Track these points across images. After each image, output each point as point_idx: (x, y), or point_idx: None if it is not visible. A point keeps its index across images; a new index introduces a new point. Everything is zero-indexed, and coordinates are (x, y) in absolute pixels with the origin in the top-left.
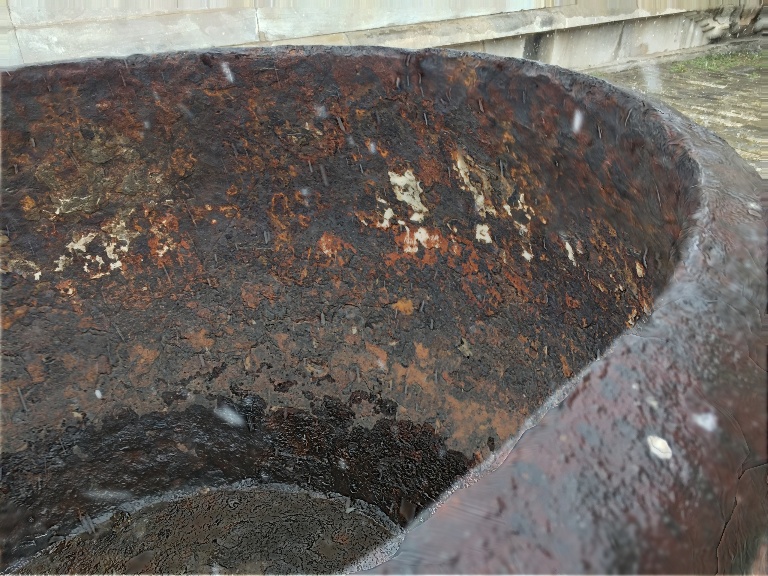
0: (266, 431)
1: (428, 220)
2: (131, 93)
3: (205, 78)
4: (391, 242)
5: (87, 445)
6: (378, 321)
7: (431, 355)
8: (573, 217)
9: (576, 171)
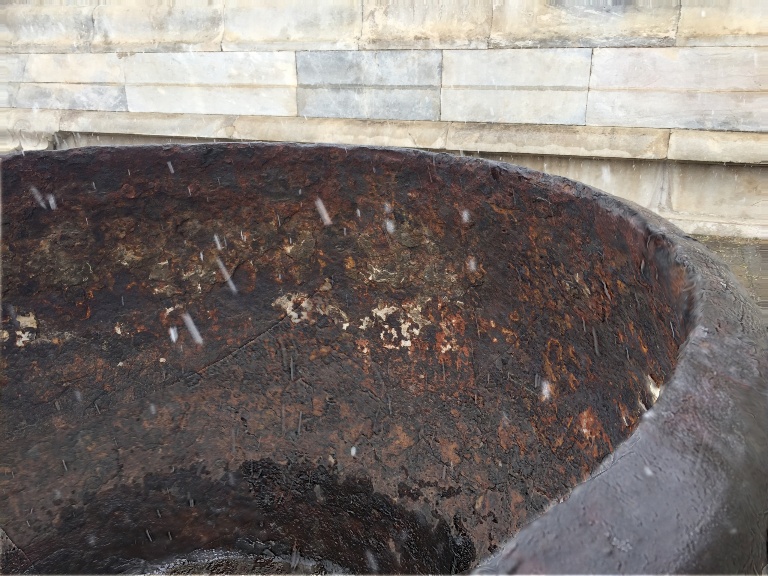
0: None
1: None
2: (436, 190)
3: (494, 192)
4: None
5: (326, 490)
6: None
7: None
8: None
9: None
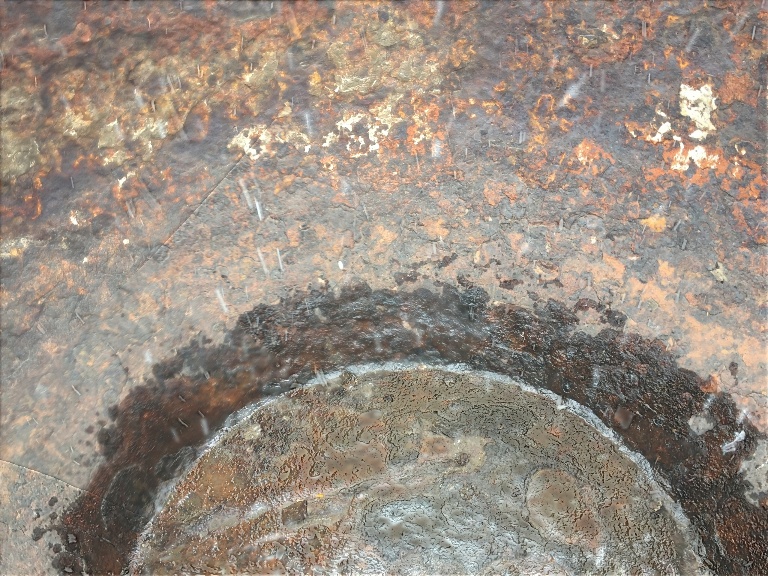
0: (485, 323)
1: (711, 139)
2: None
3: None
4: (658, 157)
5: (327, 309)
6: (621, 234)
7: (676, 275)
8: None
9: None
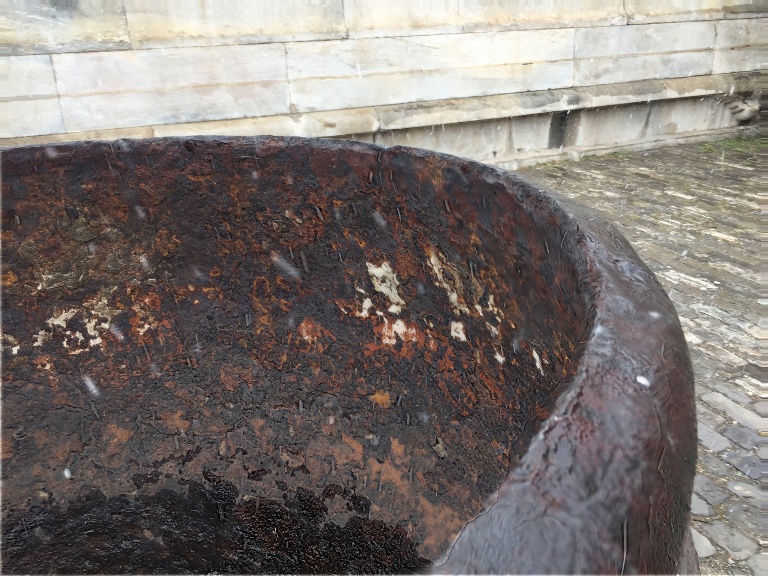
0: (236, 521)
1: (405, 313)
2: (116, 175)
3: (188, 164)
4: (370, 332)
5: (50, 527)
6: (356, 412)
7: (406, 452)
8: (538, 325)
9: (535, 281)
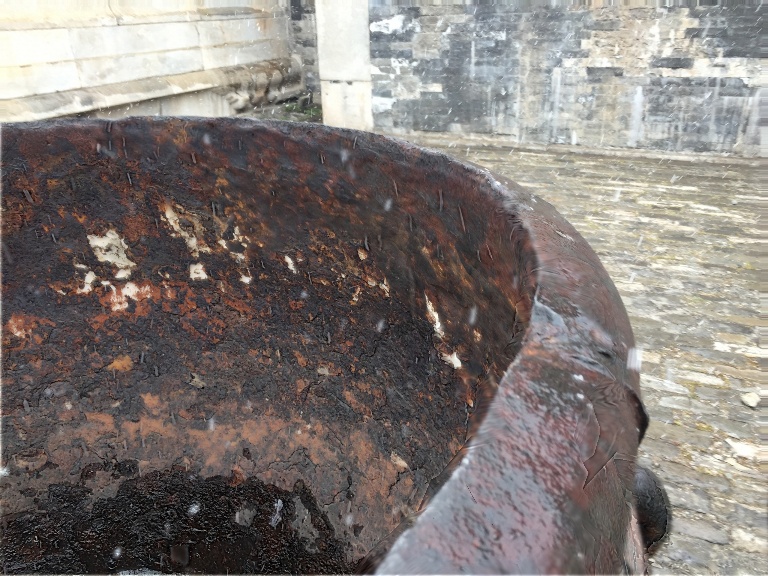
0: None
1: (136, 273)
2: None
3: None
4: (96, 305)
5: None
6: (94, 388)
7: (163, 400)
8: (290, 234)
9: (294, 195)
